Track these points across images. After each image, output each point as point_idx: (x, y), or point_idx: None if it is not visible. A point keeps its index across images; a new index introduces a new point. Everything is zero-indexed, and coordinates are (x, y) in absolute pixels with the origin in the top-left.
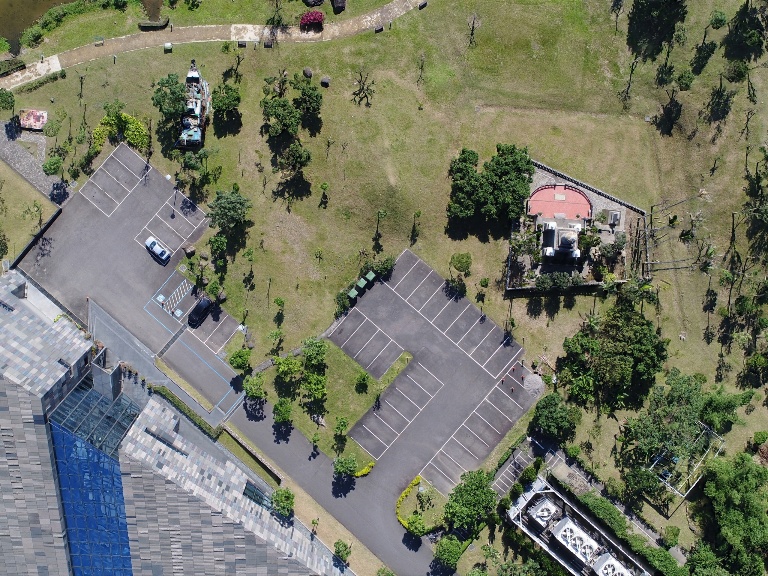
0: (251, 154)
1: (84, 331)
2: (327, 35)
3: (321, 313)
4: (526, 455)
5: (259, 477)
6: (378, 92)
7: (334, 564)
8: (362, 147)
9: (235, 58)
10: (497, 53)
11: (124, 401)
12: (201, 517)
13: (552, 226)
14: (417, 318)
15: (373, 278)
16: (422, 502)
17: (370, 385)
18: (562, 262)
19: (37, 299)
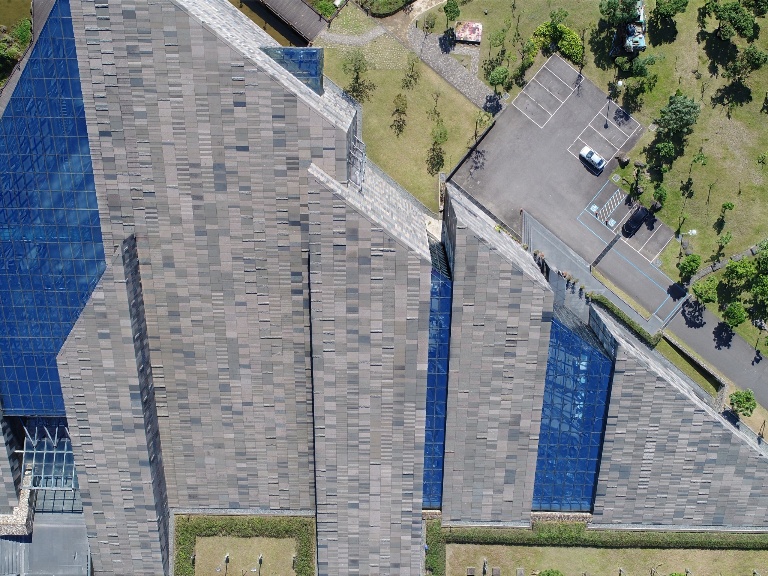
0: (688, 61)
1: (519, 242)
2: None
3: (765, 218)
4: None
5: (696, 384)
6: None
7: None
8: None
9: None
10: None
11: None
12: (683, 416)
13: None
14: None
15: None
16: None
17: None
18: None
19: None
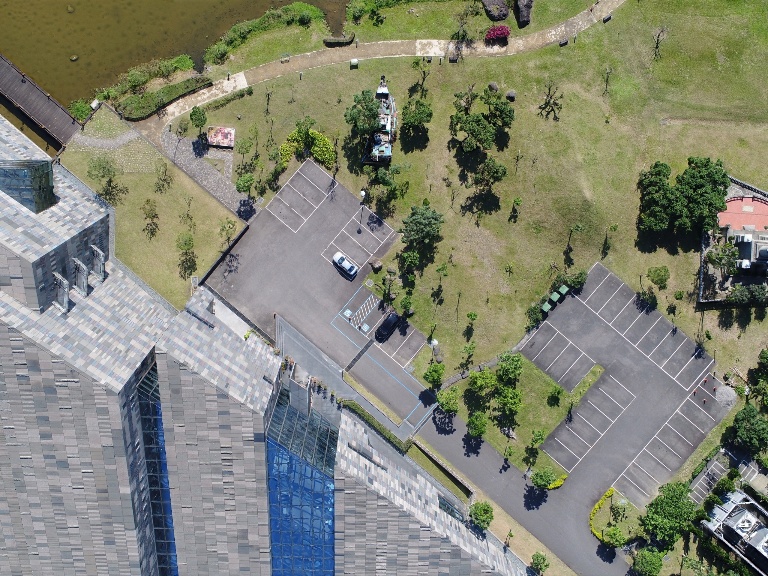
0: (439, 169)
1: (272, 346)
2: (512, 49)
3: (512, 327)
4: (727, 467)
5: (448, 490)
6: (565, 106)
7: (528, 575)
8: (553, 161)
9: (421, 73)
10: (682, 65)
11: (315, 416)
12: (409, 532)
13: (748, 239)
14: (608, 331)
15: (566, 292)
16: (615, 514)
17: (562, 398)
18: (754, 274)
19: (225, 315)
